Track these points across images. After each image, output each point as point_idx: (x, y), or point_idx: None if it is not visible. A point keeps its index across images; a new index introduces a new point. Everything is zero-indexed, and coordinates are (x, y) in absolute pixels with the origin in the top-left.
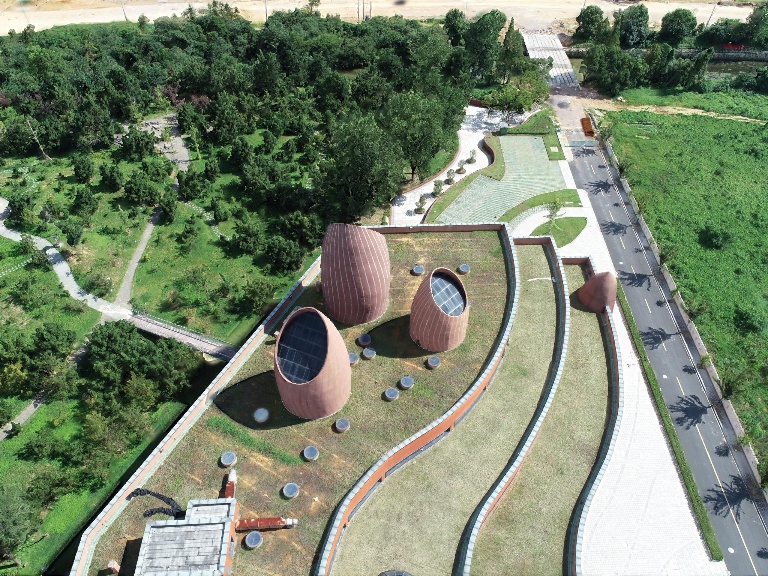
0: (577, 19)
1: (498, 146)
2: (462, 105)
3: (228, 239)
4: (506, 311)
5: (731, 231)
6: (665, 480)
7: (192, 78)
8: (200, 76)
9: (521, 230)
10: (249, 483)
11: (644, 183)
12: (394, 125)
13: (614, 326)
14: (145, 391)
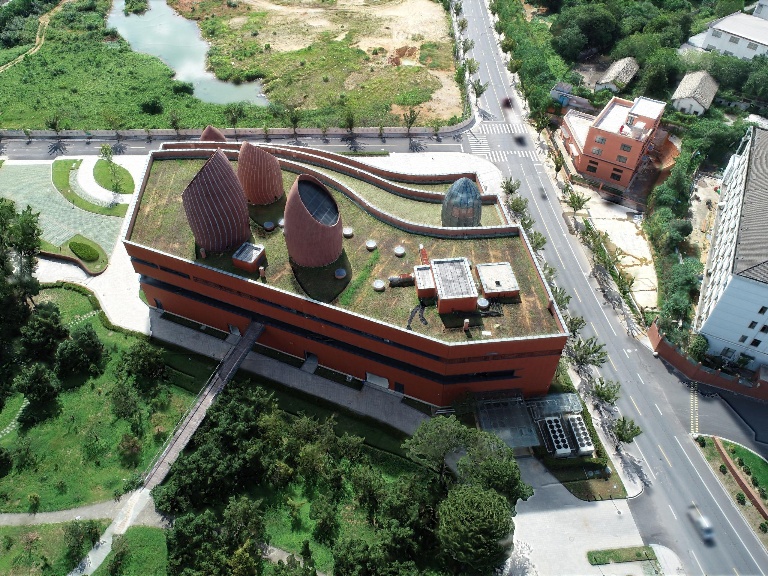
0: None
1: None
2: None
3: None
4: None
5: None
6: None
7: None
8: None
9: (100, 195)
10: (395, 273)
11: None
12: None
13: None
14: None
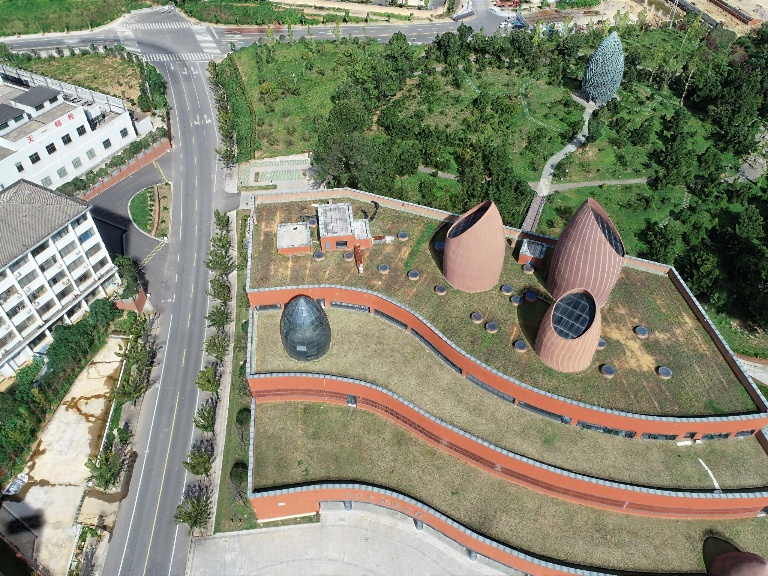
0: None
1: None
2: None
3: None
4: None
5: None
6: None
7: None
8: None
9: None
10: (388, 249)
11: None
12: None
13: None
14: None
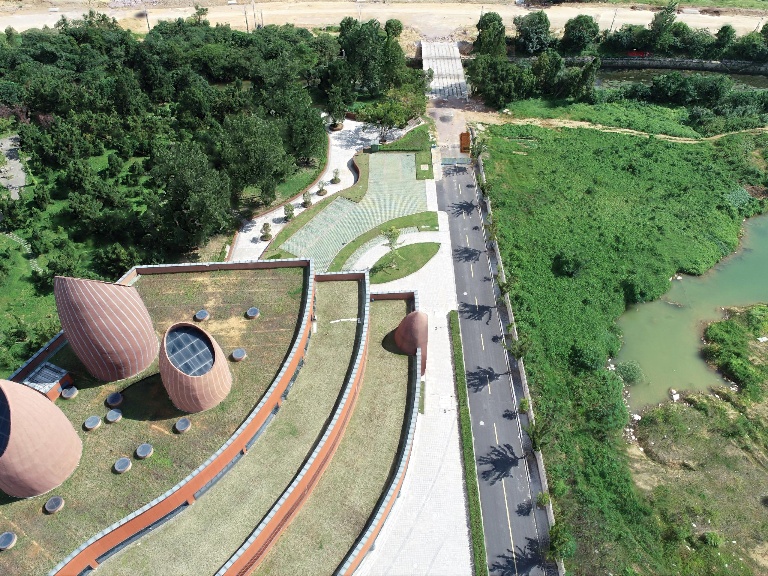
0: (477, 26)
1: (366, 165)
2: (336, 120)
3: None
4: (284, 362)
5: (584, 257)
6: (453, 546)
7: (43, 96)
8: (49, 94)
9: (367, 258)
10: None
11: (509, 204)
12: (224, 149)
13: (420, 371)
14: None
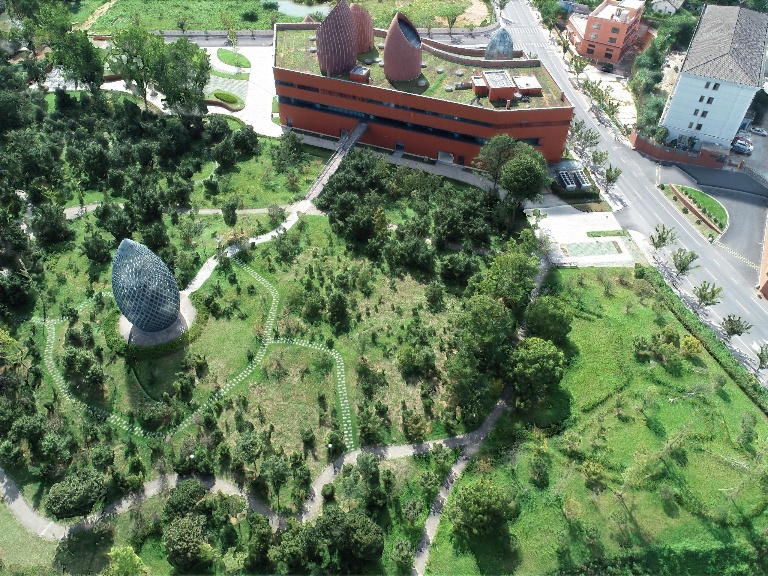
0: None
1: None
2: None
3: (214, 175)
4: None
5: (250, 8)
6: None
7: None
8: None
9: (227, 68)
10: None
11: None
12: None
13: None
14: (383, 168)
